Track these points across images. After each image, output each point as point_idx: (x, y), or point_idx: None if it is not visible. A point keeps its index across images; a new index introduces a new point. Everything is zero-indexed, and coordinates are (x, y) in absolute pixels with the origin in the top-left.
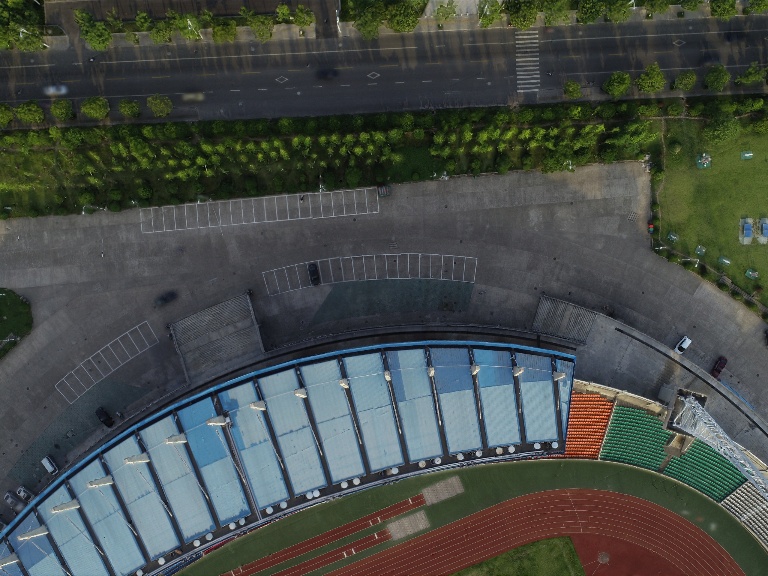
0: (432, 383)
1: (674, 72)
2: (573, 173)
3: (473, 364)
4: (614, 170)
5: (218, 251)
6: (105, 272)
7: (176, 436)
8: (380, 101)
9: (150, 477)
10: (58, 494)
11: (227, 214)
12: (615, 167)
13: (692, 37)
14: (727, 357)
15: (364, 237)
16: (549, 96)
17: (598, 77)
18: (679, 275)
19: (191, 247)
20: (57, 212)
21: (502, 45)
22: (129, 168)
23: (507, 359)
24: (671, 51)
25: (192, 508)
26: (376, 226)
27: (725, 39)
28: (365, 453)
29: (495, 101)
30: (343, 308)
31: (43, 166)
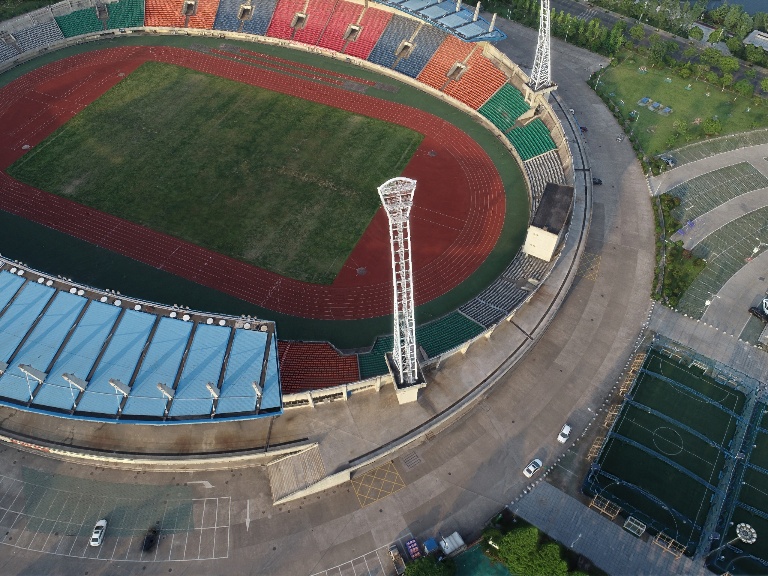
0: None
1: None
2: (572, 46)
3: None
4: (593, 55)
5: None
6: None
7: None
8: None
9: None
10: None
11: None
12: None
13: None
14: (589, 131)
15: None
16: None
17: None
18: (592, 95)
19: None
20: None
21: (579, 8)
22: None
23: None
24: None
25: None
26: None
27: None
28: None
29: None
30: None
31: None
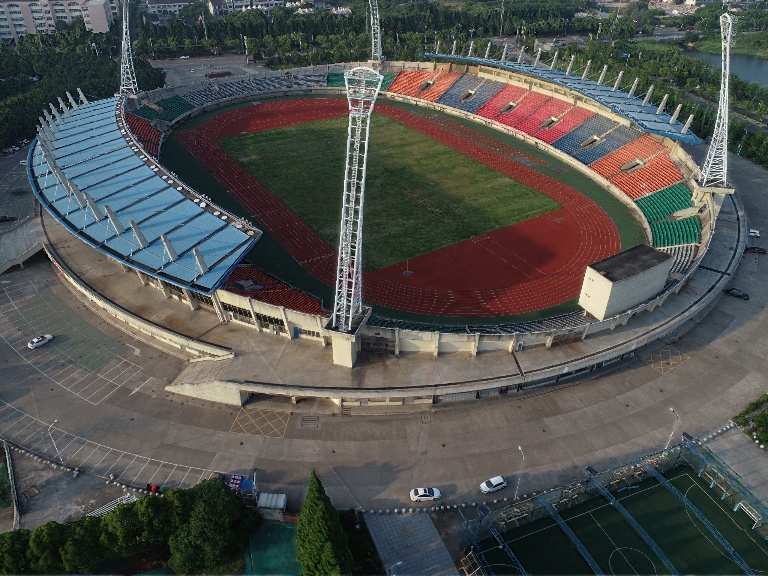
0: None
1: None
2: None
3: None
4: None
5: None
6: None
7: None
8: None
9: None
10: None
11: None
12: None
13: None
14: None
15: None
16: None
17: None
18: None
19: None
20: None
21: None
22: None
23: None
24: None
25: None
26: None
27: None
28: None
29: None
30: None
31: None
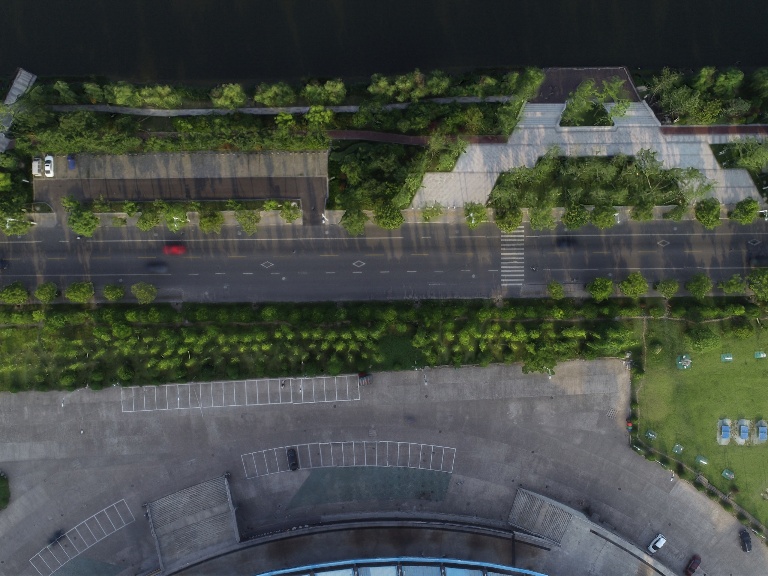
0: None
1: (657, 272)
2: (554, 368)
3: None
4: (595, 366)
5: (198, 432)
6: (84, 449)
7: None
8: (364, 289)
9: None
10: None
11: (208, 396)
12: (596, 363)
13: (676, 238)
14: (701, 556)
15: (344, 424)
16: (533, 291)
17: (582, 274)
18: (656, 473)
19: (171, 427)
20: (38, 388)
21: (488, 239)
22: (112, 348)
23: None
24: (655, 251)
25: None
26: (356, 413)
27: (709, 241)
28: None
29: (479, 294)
30: (320, 493)
31: (26, 343)
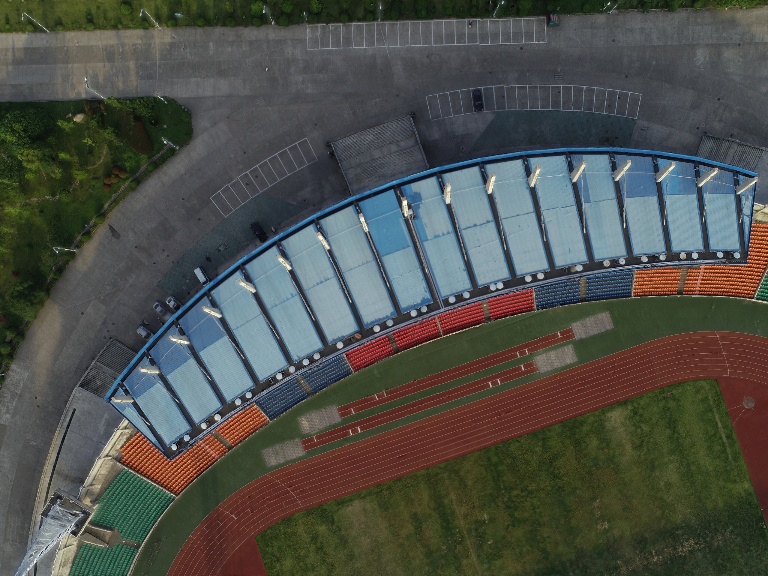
0: (616, 188)
1: None
2: (742, 14)
3: (663, 166)
4: None
5: (383, 72)
6: (268, 86)
7: (364, 219)
8: None
9: (330, 264)
10: (233, 279)
11: (394, 35)
12: None
13: None
14: None
15: (530, 66)
16: None
17: None
18: None
19: (356, 66)
20: (224, 23)
21: None
22: None
23: (691, 170)
24: None
25: (373, 295)
26: (543, 56)
27: None
28: (549, 249)
29: None
30: (504, 137)
31: None
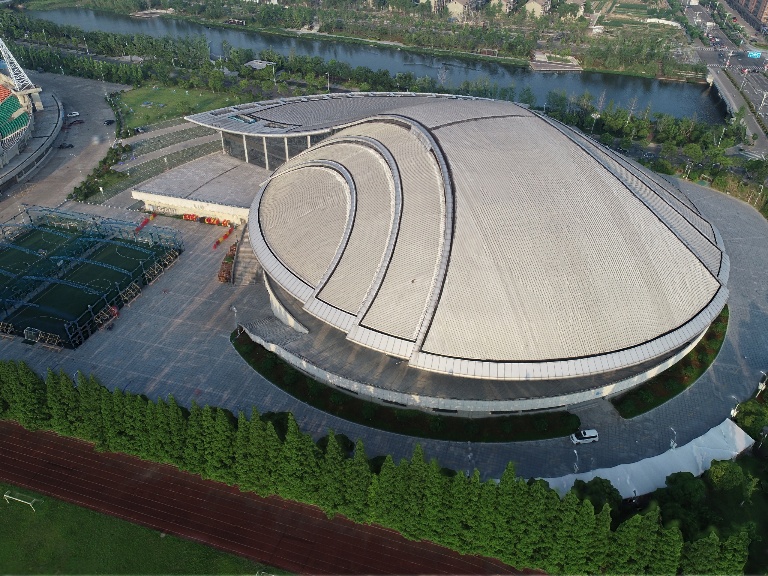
0: None
1: None
2: (109, 83)
3: None
4: None
5: None
6: None
7: None
8: None
9: None
10: None
11: None
12: None
13: None
14: None
15: None
16: None
17: None
18: (104, 105)
19: None
20: None
21: None
22: None
23: None
24: None
25: None
26: None
27: None
28: None
29: None
30: None
31: None
